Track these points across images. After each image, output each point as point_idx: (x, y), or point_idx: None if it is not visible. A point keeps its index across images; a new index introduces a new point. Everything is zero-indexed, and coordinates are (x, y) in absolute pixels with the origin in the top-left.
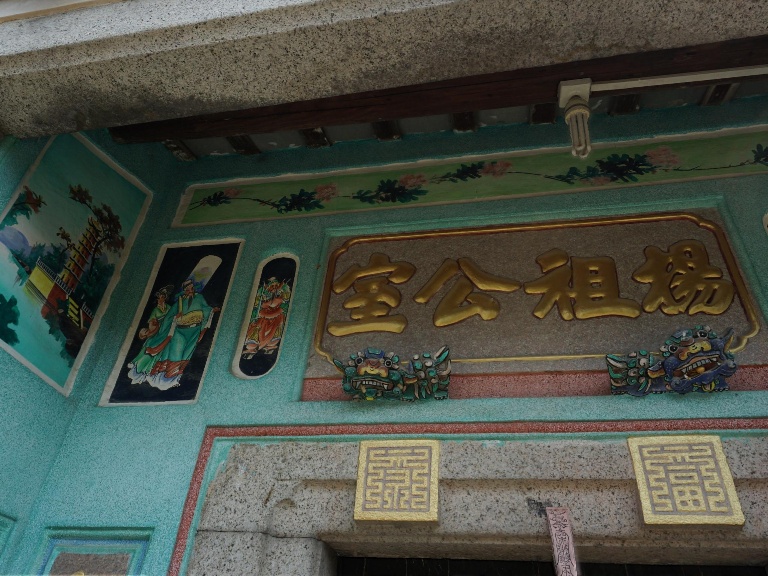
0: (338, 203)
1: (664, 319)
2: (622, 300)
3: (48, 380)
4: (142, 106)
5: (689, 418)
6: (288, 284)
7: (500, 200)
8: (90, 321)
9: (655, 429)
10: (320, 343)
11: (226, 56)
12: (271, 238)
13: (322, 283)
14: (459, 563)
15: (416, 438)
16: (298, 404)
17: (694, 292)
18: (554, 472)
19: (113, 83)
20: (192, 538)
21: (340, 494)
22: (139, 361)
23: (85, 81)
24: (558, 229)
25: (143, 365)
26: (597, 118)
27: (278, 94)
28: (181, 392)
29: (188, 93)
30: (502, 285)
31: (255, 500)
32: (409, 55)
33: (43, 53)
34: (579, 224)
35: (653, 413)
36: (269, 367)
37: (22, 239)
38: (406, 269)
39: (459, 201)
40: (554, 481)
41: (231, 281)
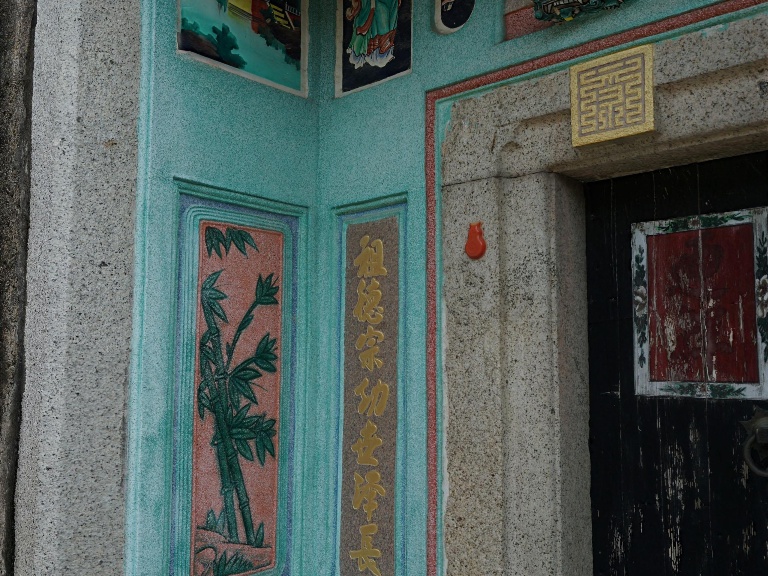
0: None
1: None
2: None
3: (284, 88)
4: None
5: None
6: None
7: None
8: (299, 19)
9: None
10: None
11: None
12: None
13: None
14: (709, 165)
15: (626, 48)
16: (501, 46)
17: None
18: None
19: None
20: (439, 193)
21: (560, 126)
22: (354, 44)
23: None
24: None
25: (359, 47)
26: None
27: None
28: (397, 64)
29: None
30: None
31: (482, 150)
32: None
33: None
34: None
35: None
36: (469, 13)
37: None
38: None
39: None
40: None
41: None
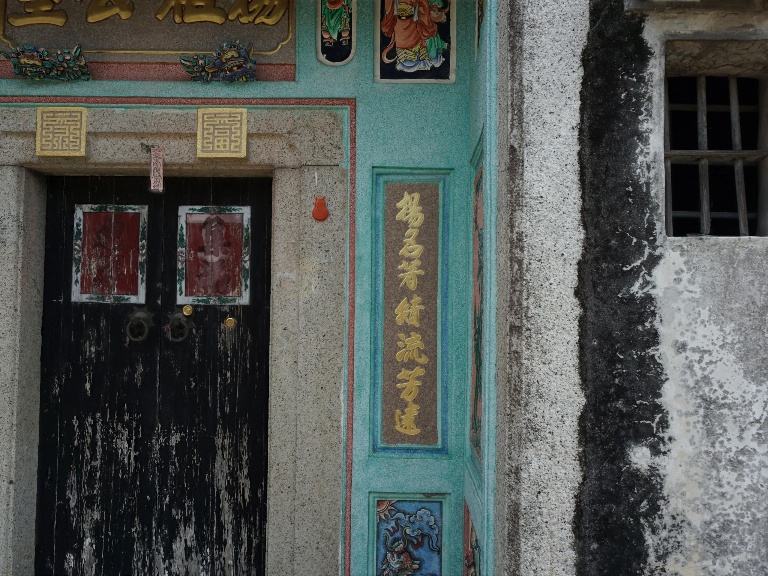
0: None
1: (239, 26)
2: (214, 9)
3: None
4: None
5: (231, 98)
6: None
7: None
8: None
9: (212, 104)
10: (3, 31)
11: None
12: None
13: None
14: (120, 178)
15: (72, 106)
16: None
17: (261, 6)
18: (153, 128)
19: None
20: None
21: (29, 140)
22: None
23: None
24: None
25: None
26: None
27: None
28: None
29: None
30: None
31: None
32: None
33: None
34: None
35: (212, 94)
36: None
37: None
38: None
39: None
40: (154, 134)
41: None
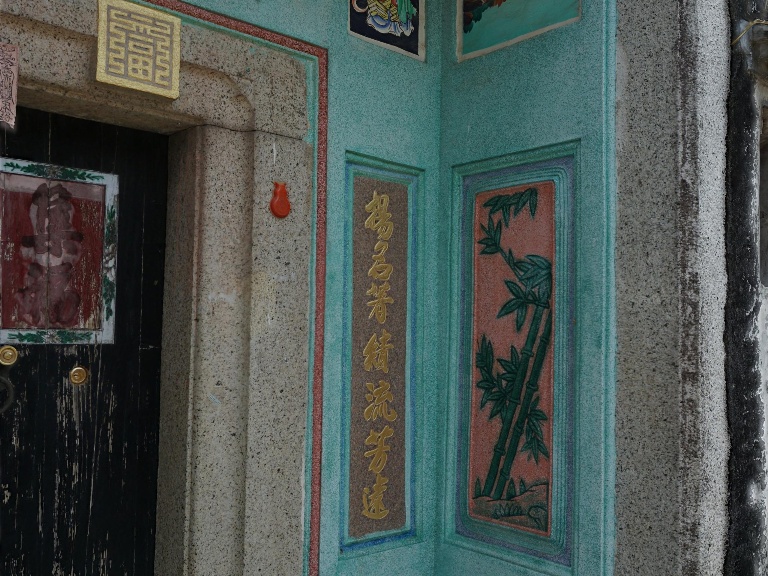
0: None
1: None
2: None
3: None
4: None
5: None
6: None
7: None
8: None
9: None
10: None
11: None
12: None
13: None
14: None
15: None
16: None
17: None
18: (13, 6)
19: None
20: None
21: None
22: None
23: None
24: None
25: None
26: None
27: None
28: None
29: None
30: None
31: None
32: None
33: None
34: None
35: None
36: None
37: None
38: None
39: None
40: (10, 15)
41: None
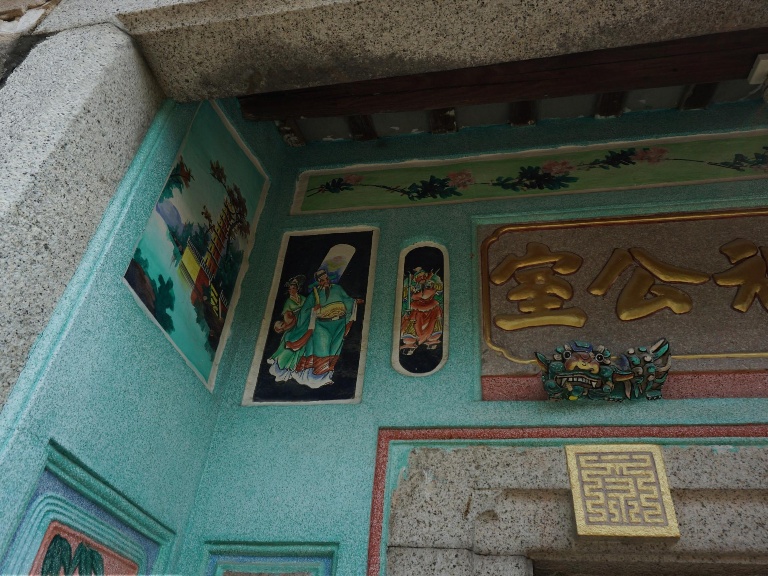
0: (477, 190)
1: None
2: None
3: (198, 374)
4: (332, 65)
5: None
6: (438, 274)
7: (666, 187)
8: (226, 311)
9: None
10: (490, 338)
11: (449, 5)
12: (410, 226)
13: (479, 273)
14: None
15: (632, 442)
16: (484, 404)
17: None
18: None
19: (307, 37)
20: (385, 555)
21: (548, 505)
22: (280, 356)
23: (275, 34)
24: (737, 218)
25: (285, 361)
26: (754, 104)
27: (493, 52)
28: (336, 390)
29: (390, 50)
30: (688, 276)
31: (452, 512)
32: (660, 7)
33: (231, 1)
34: (761, 213)
35: None
36: (436, 363)
37: (176, 215)
38: (572, 259)
39: (617, 188)
40: None
41: (372, 271)
